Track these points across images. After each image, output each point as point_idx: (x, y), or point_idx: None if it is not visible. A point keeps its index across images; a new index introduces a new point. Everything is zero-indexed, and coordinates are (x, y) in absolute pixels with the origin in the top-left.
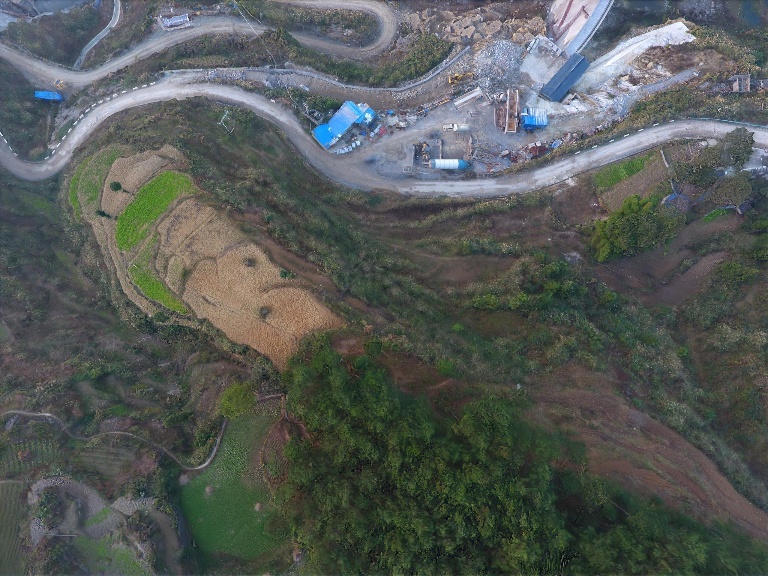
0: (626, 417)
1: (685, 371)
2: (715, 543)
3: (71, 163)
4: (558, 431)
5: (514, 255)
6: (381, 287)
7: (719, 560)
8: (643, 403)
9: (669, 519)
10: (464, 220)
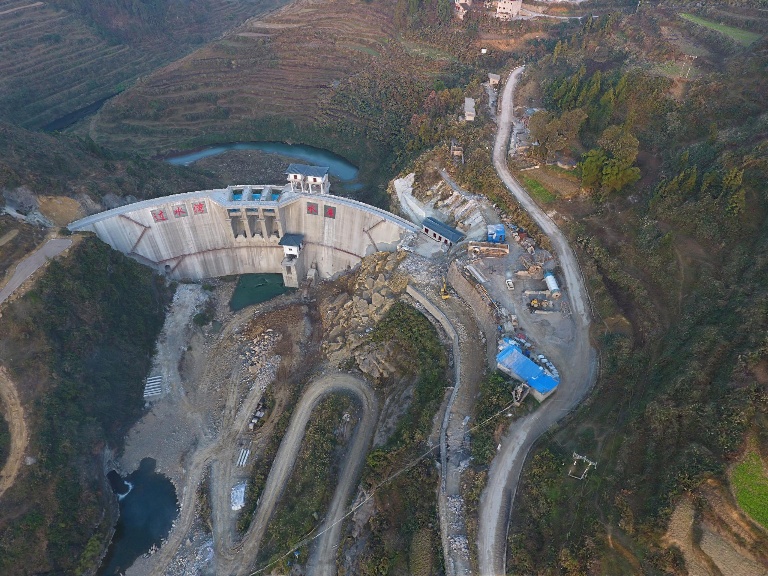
0: None
1: None
2: None
3: None
4: None
5: None
6: (765, 272)
7: None
8: None
9: None
10: None
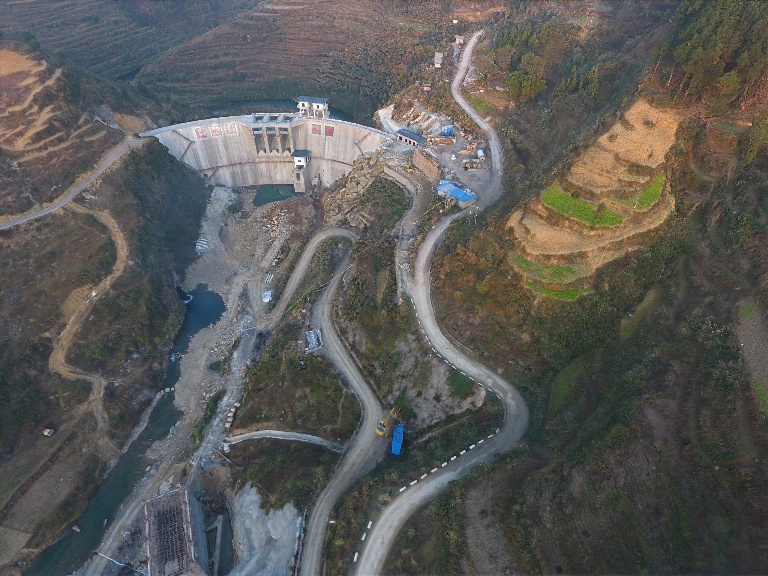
0: None
1: None
2: None
3: (511, 350)
4: None
5: None
6: None
7: None
8: None
9: None
10: None
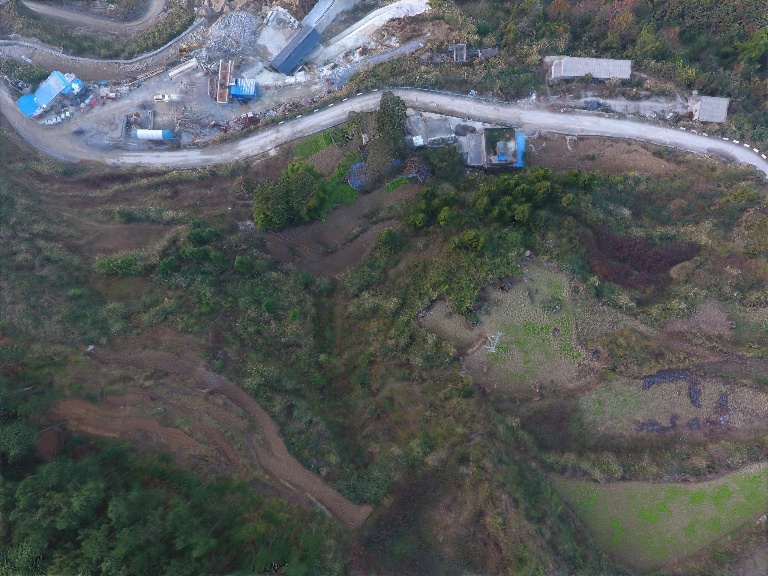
0: (200, 379)
1: (308, 336)
2: (129, 493)
3: None
4: (100, 390)
5: (179, 223)
6: (10, 252)
7: (106, 508)
8: (230, 366)
9: (163, 475)
10: (150, 189)
